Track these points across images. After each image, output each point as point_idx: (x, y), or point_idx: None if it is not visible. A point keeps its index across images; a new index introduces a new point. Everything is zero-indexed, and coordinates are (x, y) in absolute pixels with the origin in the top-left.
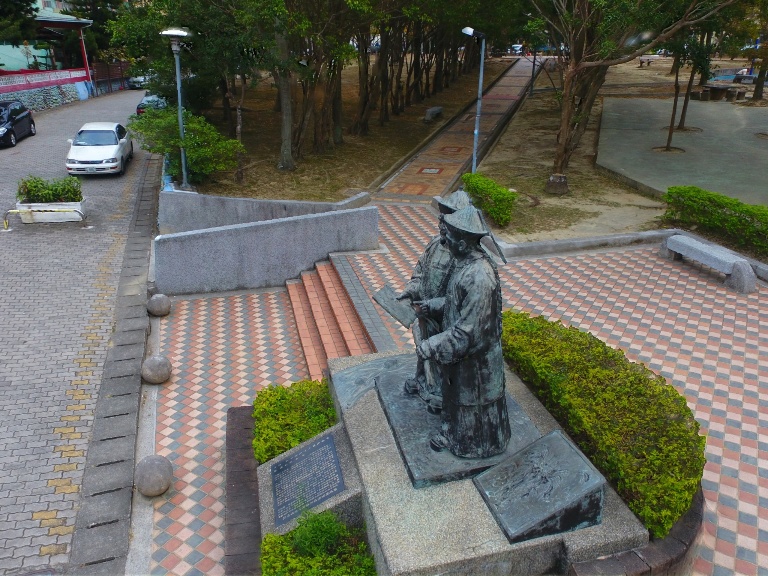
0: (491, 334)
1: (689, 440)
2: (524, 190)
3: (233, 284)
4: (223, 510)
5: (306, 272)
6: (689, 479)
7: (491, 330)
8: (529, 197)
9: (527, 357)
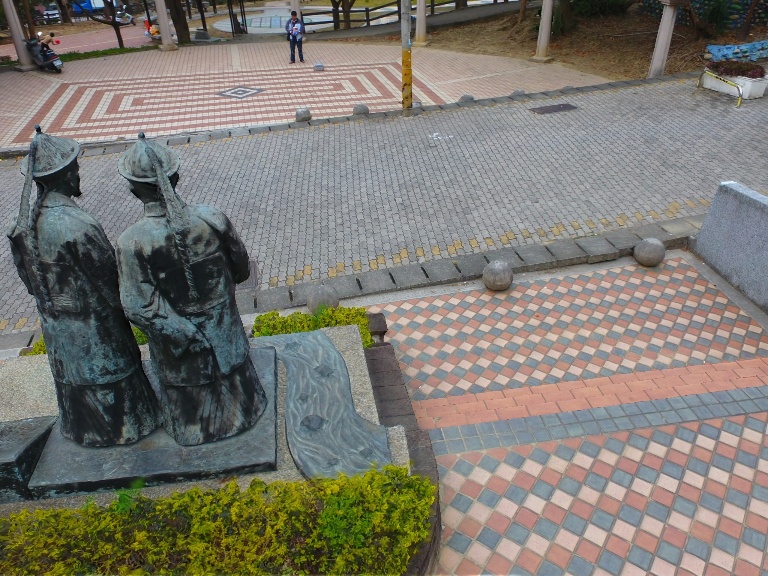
0: None
1: None
2: None
3: (762, 297)
4: None
5: None
6: None
7: None
8: None
9: None
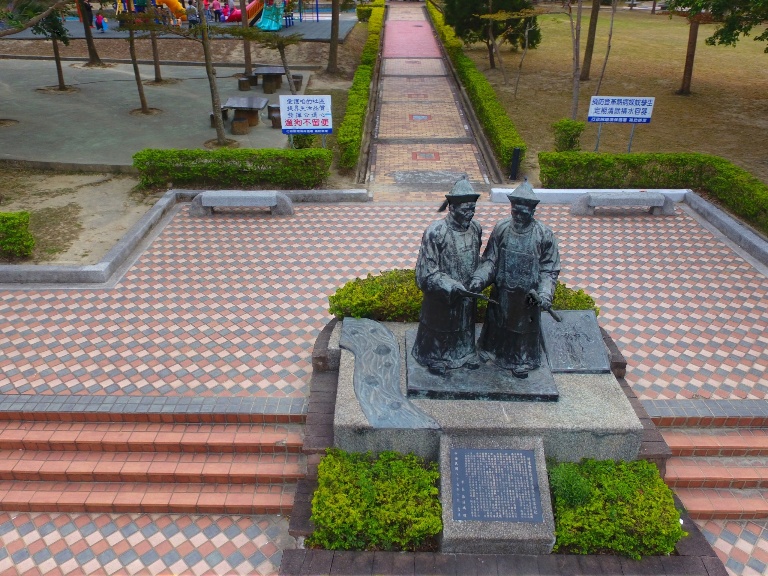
0: None
1: None
2: None
3: None
4: None
5: None
6: None
7: None
8: None
9: None
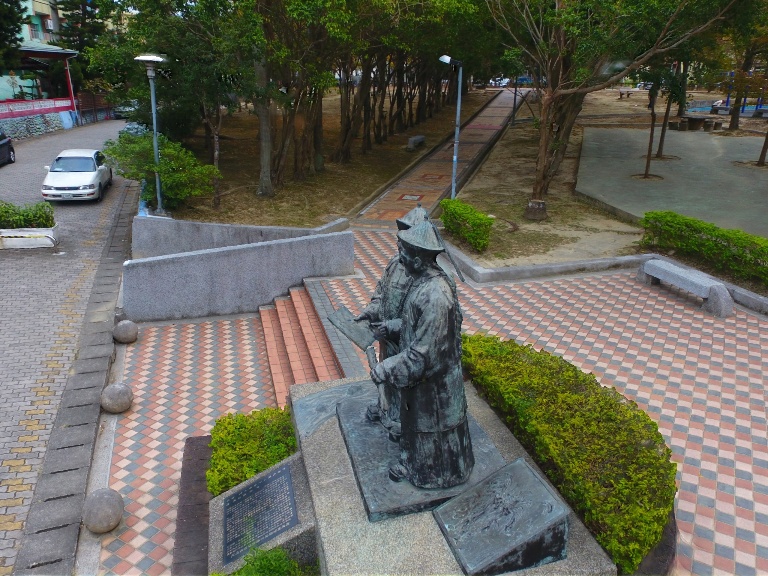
0: (449, 356)
1: (659, 467)
2: (503, 216)
3: (204, 310)
4: None
5: (280, 298)
6: (659, 509)
7: (449, 352)
8: (508, 223)
9: (495, 382)
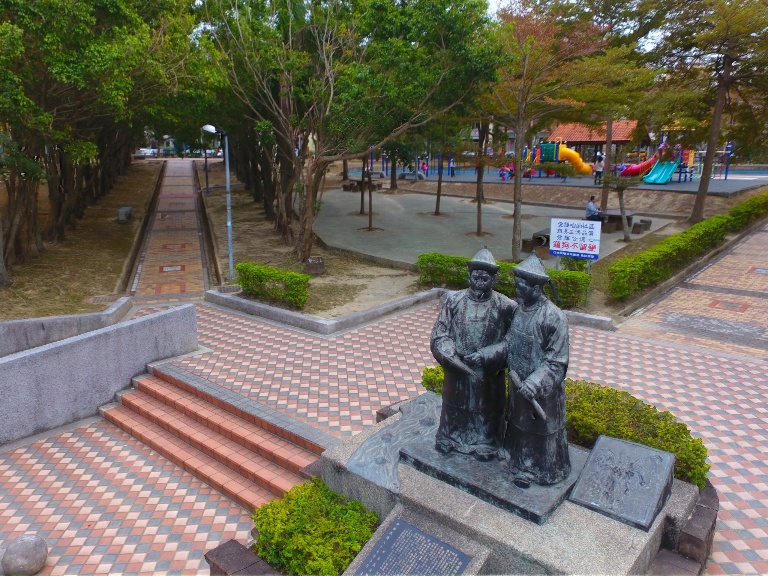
0: None
1: (664, 416)
2: None
3: (29, 428)
4: None
5: (123, 392)
6: None
7: None
8: None
9: None
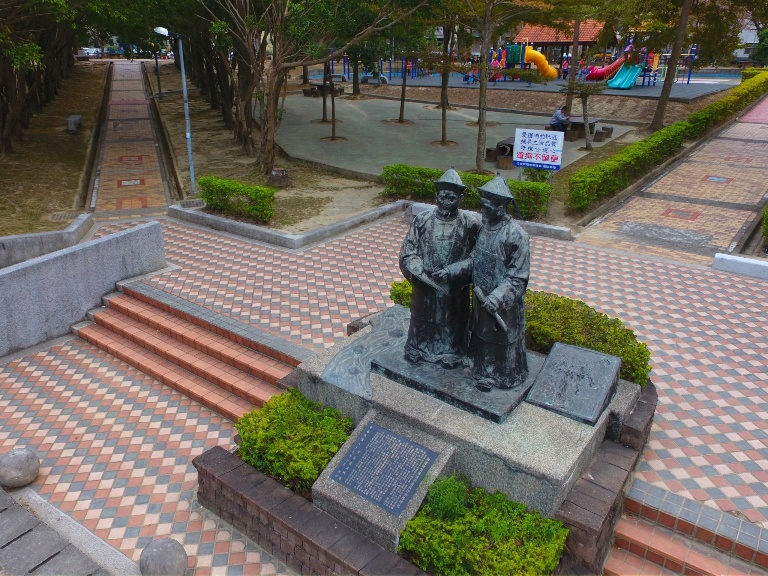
0: None
1: (614, 323)
2: None
3: (3, 348)
4: (262, 557)
5: (94, 310)
6: None
7: None
8: None
9: None
